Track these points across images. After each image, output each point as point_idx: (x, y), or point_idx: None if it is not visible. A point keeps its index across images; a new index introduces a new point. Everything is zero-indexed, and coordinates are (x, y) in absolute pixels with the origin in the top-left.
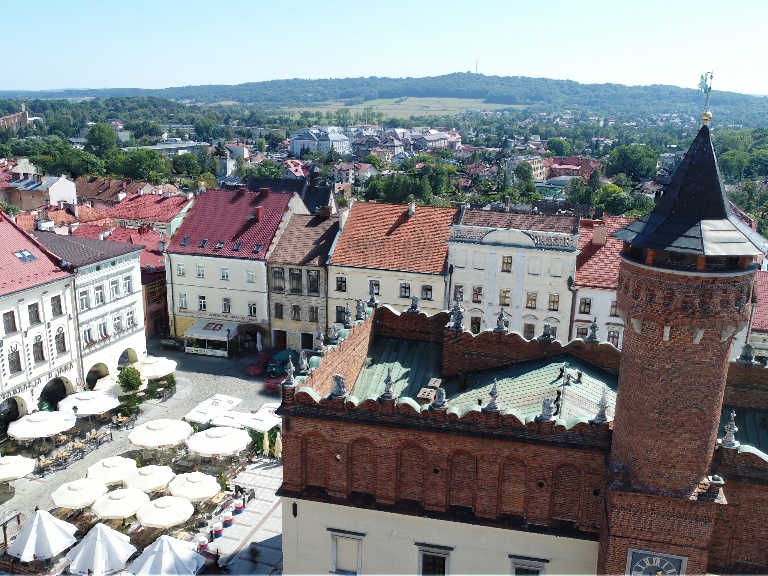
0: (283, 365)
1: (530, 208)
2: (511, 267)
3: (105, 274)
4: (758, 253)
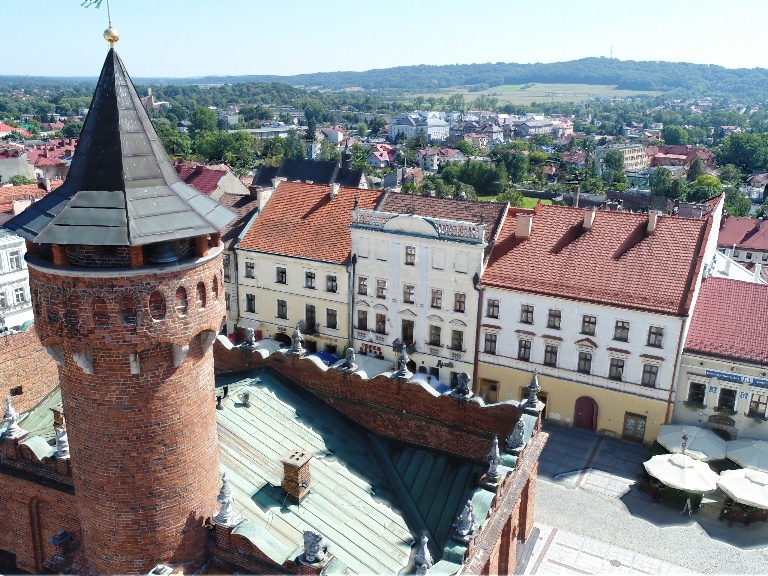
0: None
1: (604, 199)
2: (415, 259)
3: None
4: (120, 243)
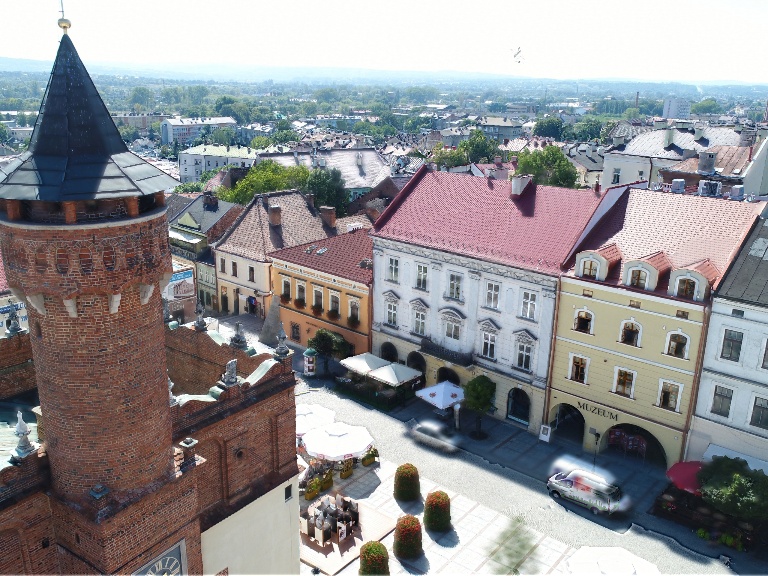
0: None
1: None
2: None
3: None
4: None
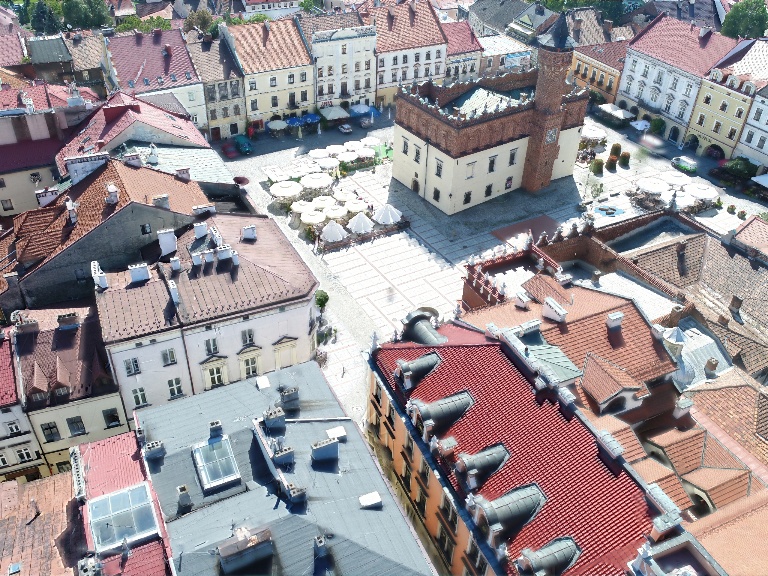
0: (250, 145)
1: None
2: (346, 51)
3: None
4: None
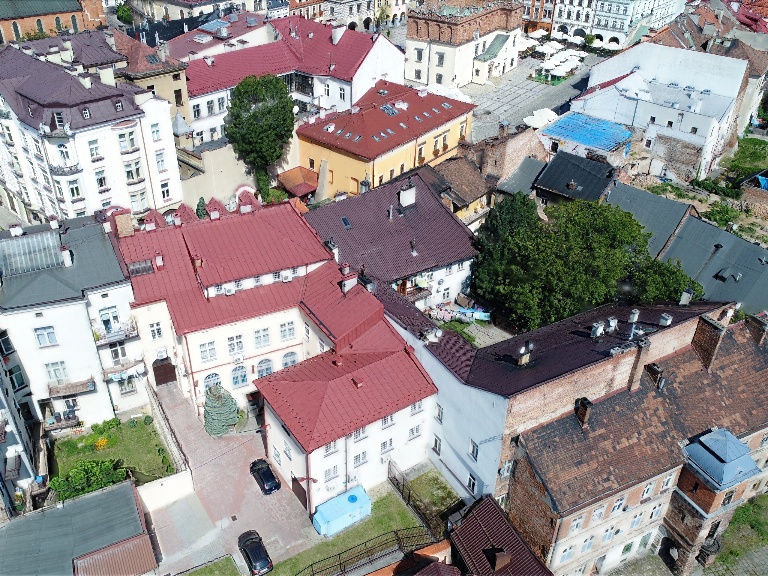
0: None
1: None
2: None
3: (614, 1)
4: None
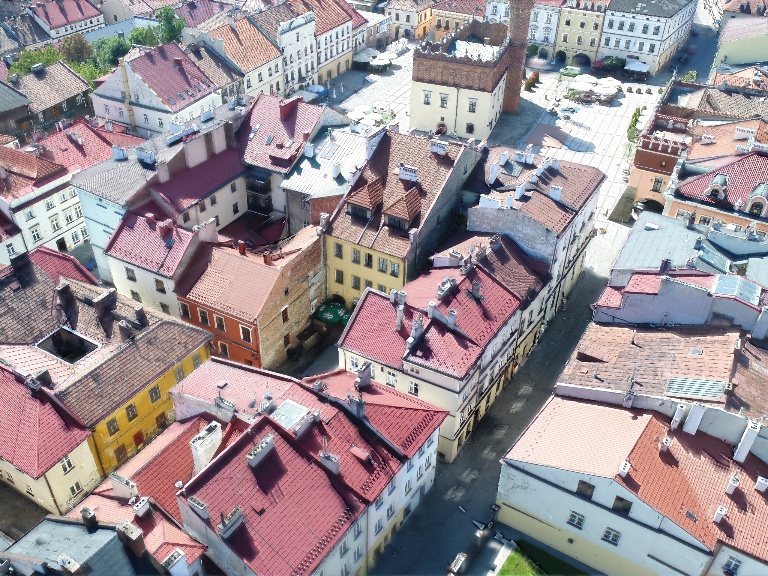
0: None
1: None
2: (299, 38)
3: None
4: None
